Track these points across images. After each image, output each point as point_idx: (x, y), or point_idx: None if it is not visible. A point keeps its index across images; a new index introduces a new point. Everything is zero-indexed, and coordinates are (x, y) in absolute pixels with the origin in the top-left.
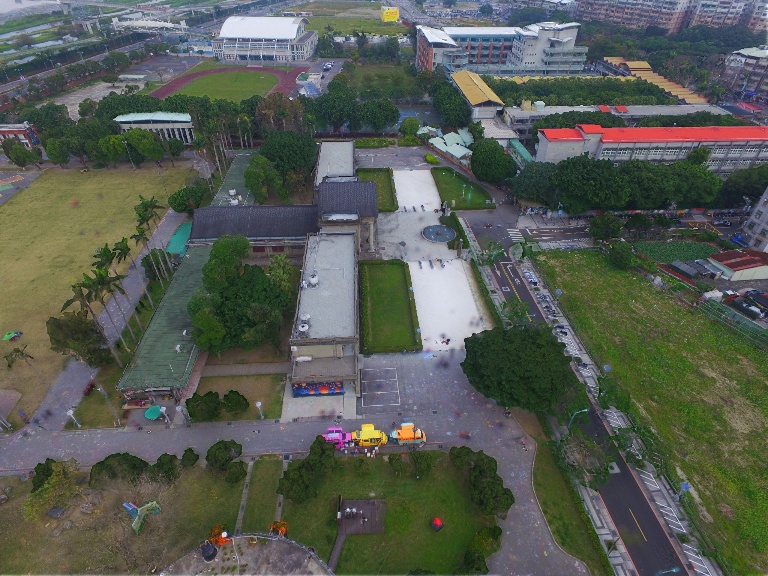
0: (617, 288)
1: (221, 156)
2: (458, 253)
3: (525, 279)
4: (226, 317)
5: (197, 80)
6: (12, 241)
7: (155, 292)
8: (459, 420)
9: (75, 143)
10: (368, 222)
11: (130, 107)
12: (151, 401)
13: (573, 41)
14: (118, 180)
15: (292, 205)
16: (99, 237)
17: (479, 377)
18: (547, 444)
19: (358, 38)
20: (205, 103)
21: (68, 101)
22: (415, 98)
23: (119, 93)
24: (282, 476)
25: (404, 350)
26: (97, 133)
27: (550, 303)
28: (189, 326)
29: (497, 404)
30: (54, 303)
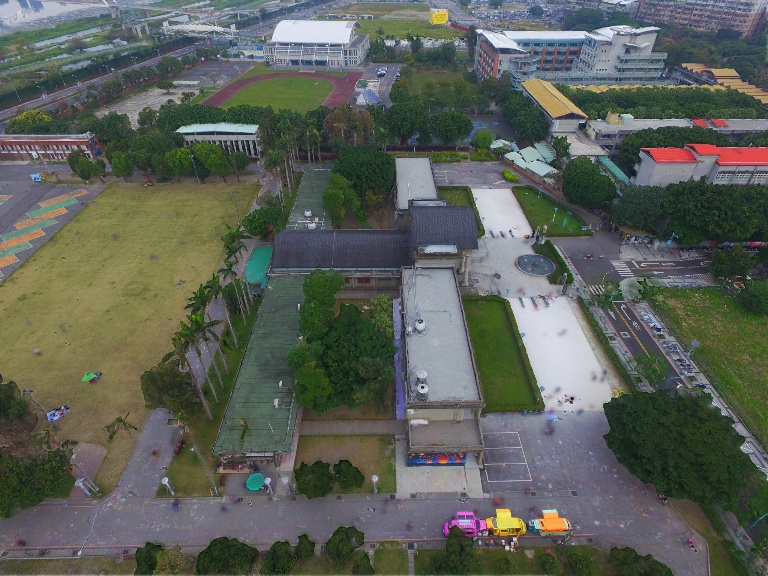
0: (756, 338)
1: (290, 172)
2: (563, 290)
3: (645, 323)
4: (330, 370)
5: (250, 86)
6: (82, 264)
7: (237, 328)
8: (606, 505)
9: (141, 157)
10: (466, 254)
11: (193, 117)
12: (249, 465)
13: (651, 46)
14: (184, 196)
15: (375, 230)
16: (171, 261)
17: (631, 456)
18: (733, 552)
19: (413, 42)
20: (269, 114)
21: (125, 108)
22: (481, 107)
23: (174, 100)
24: (410, 572)
25: (525, 410)
26: (162, 146)
27: (681, 355)
28: (283, 375)
29: (657, 492)
30: (132, 338)
